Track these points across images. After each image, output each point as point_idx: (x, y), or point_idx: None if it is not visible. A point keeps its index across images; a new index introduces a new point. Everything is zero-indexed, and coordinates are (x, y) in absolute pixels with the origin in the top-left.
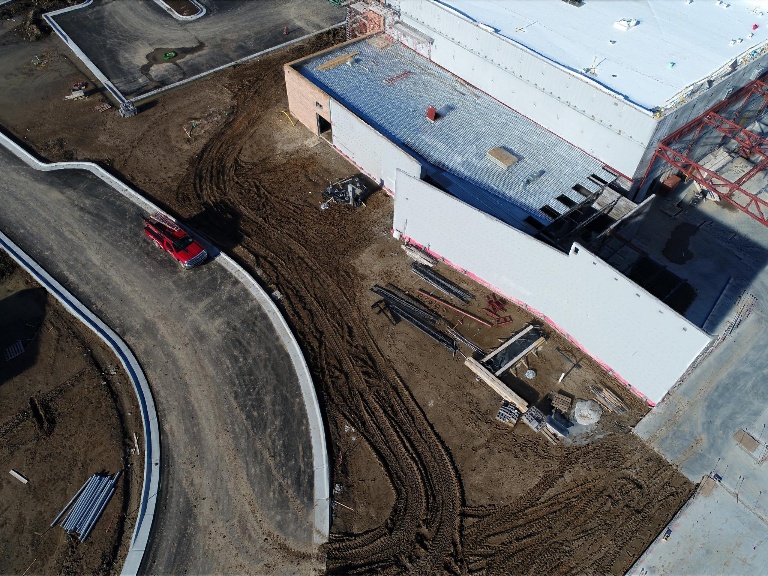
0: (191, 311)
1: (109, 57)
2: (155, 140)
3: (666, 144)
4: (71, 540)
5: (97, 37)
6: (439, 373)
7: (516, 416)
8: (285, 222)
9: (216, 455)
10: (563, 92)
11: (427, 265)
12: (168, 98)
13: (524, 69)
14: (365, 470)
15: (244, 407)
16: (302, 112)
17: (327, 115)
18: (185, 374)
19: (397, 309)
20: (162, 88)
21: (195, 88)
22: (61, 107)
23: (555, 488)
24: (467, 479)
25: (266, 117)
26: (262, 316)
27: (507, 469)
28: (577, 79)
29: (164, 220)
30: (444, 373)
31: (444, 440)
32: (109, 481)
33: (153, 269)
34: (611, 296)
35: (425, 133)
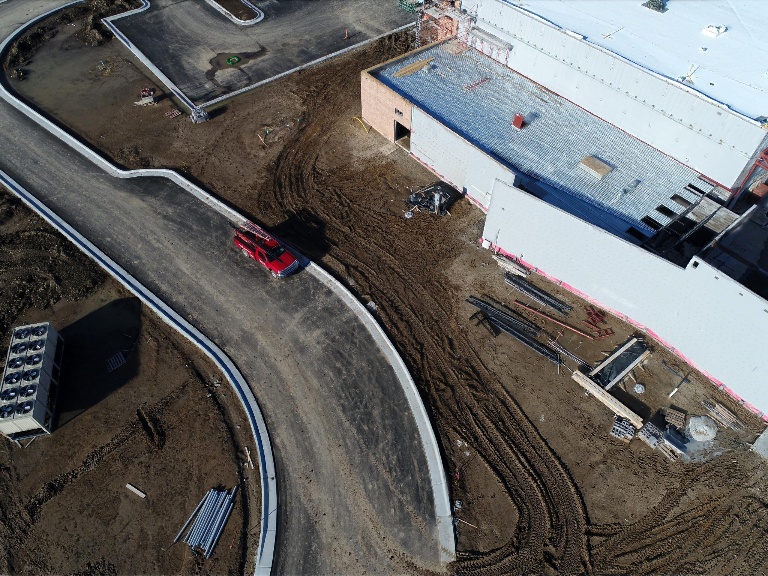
0: (288, 322)
1: (173, 62)
2: (229, 147)
3: (766, 154)
4: (196, 556)
5: (158, 42)
6: (546, 387)
7: (632, 432)
8: (371, 231)
9: (331, 470)
10: (658, 100)
11: (520, 276)
12: (237, 104)
13: (615, 77)
14: (483, 486)
15: (353, 421)
16: (377, 119)
17: (407, 122)
18: (290, 386)
19: (496, 321)
20: (230, 94)
21: (263, 94)
22: (131, 113)
23: (680, 507)
24: (588, 496)
25: (338, 123)
26: (360, 327)
27: (628, 486)
28: (676, 88)
29: (254, 229)
30: (551, 387)
31: (560, 456)
32: (227, 496)
33: (244, 279)
34: (732, 311)
35: (512, 141)
